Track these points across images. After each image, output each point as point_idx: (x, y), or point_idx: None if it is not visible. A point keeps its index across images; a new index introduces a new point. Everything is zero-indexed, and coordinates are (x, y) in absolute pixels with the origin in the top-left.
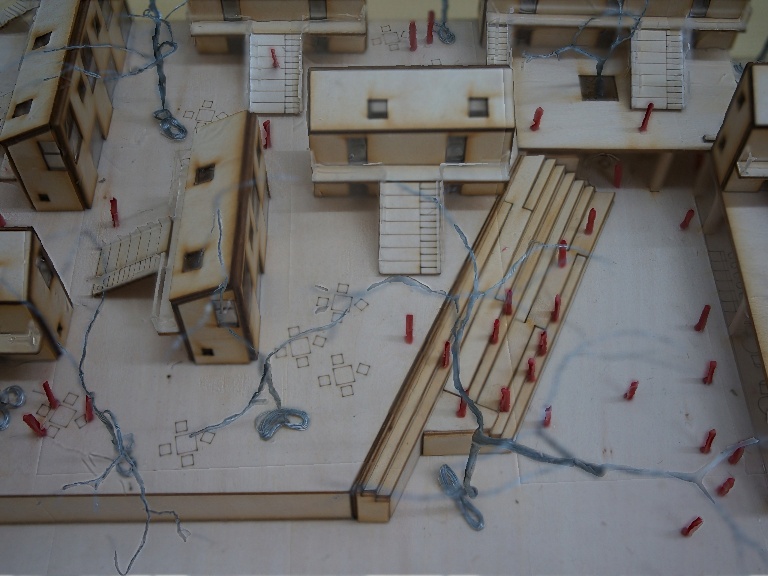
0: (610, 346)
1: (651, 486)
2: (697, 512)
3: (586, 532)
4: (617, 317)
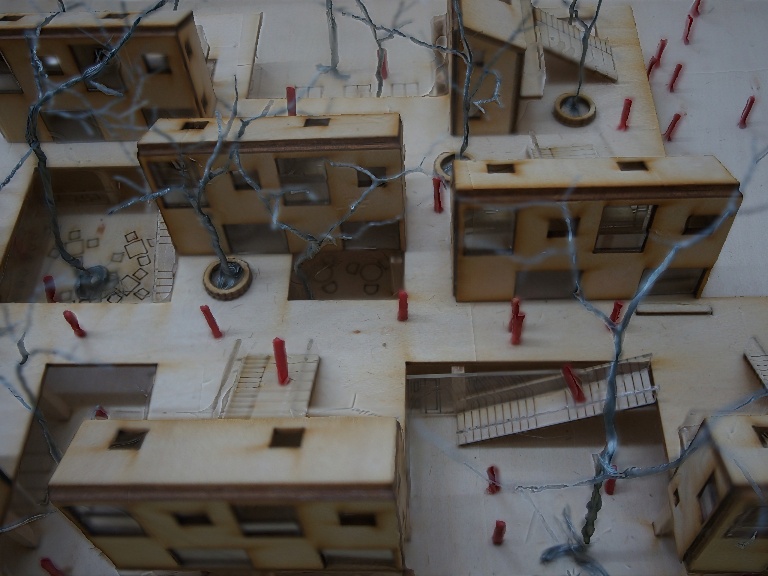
0: (766, 166)
1: (716, 67)
2: (677, 54)
3: (765, 41)
4: (762, 192)
